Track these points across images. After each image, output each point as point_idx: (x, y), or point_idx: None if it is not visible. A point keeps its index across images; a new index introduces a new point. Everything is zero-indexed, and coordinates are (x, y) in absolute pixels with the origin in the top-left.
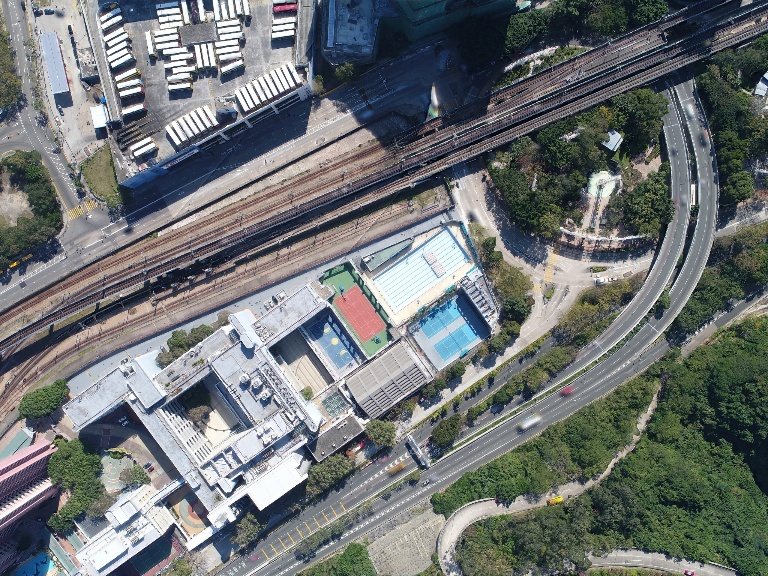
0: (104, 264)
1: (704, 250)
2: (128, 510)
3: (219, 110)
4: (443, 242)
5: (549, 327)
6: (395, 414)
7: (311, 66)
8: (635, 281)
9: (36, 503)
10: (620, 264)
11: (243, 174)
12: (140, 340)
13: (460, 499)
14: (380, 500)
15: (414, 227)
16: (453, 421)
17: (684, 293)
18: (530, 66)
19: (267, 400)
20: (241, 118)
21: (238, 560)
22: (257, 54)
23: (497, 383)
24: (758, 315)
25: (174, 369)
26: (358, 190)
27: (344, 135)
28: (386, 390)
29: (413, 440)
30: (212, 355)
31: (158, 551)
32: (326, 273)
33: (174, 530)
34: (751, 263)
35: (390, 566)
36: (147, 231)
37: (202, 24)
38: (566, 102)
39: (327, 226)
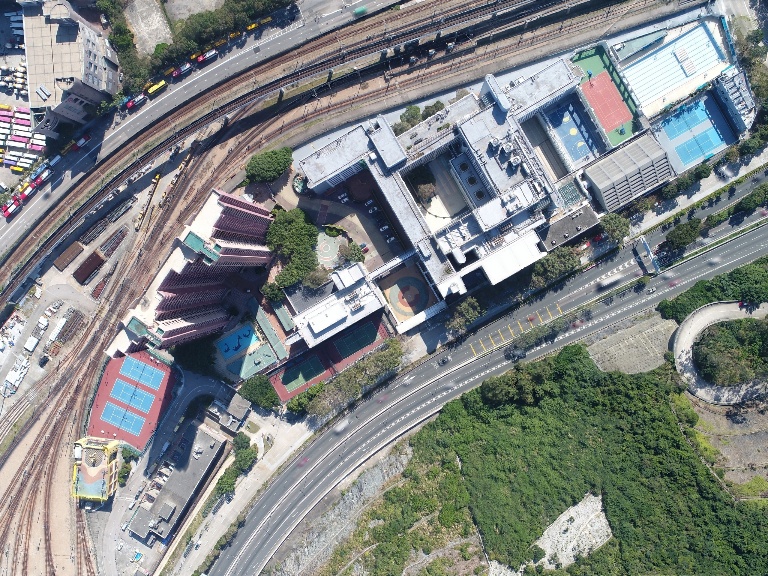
0: (342, 34)
1: None
2: (354, 274)
3: None
4: (697, 39)
5: None
6: (629, 214)
7: None
8: None
9: (261, 259)
10: None
11: None
12: (369, 116)
13: (695, 303)
14: (601, 304)
15: (668, 20)
16: (694, 223)
17: None
18: None
19: (514, 169)
20: None
21: (445, 353)
22: None
23: (738, 194)
24: None
25: (418, 132)
26: None
27: None
28: (630, 180)
29: (646, 242)
30: (461, 118)
31: (363, 336)
32: (575, 56)
33: (382, 316)
34: None
35: (615, 364)
36: (388, 4)
37: None
38: None
39: (576, 12)
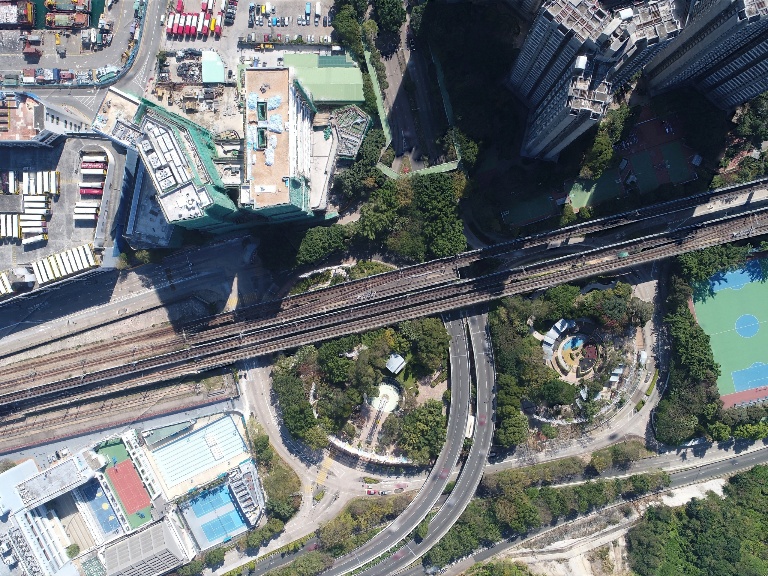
0: None
1: (472, 485)
2: None
3: (12, 281)
4: (225, 427)
5: (315, 528)
6: None
7: (113, 246)
8: (397, 504)
9: None
10: (393, 479)
11: (46, 331)
12: None
13: None
14: None
15: (198, 409)
16: None
17: (446, 523)
18: (330, 274)
19: (13, 564)
20: (37, 288)
21: None
22: (61, 229)
23: (257, 572)
24: (514, 560)
25: None
26: (143, 370)
27: (143, 311)
28: (137, 568)
29: None
30: None
31: None
32: (102, 443)
33: None
34: (506, 513)
35: None
36: None
37: (10, 196)
38: (354, 319)
39: (116, 394)
